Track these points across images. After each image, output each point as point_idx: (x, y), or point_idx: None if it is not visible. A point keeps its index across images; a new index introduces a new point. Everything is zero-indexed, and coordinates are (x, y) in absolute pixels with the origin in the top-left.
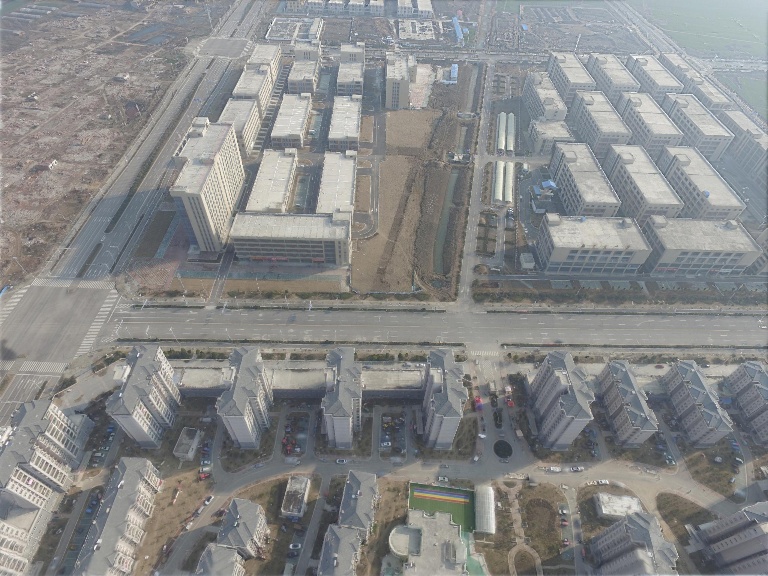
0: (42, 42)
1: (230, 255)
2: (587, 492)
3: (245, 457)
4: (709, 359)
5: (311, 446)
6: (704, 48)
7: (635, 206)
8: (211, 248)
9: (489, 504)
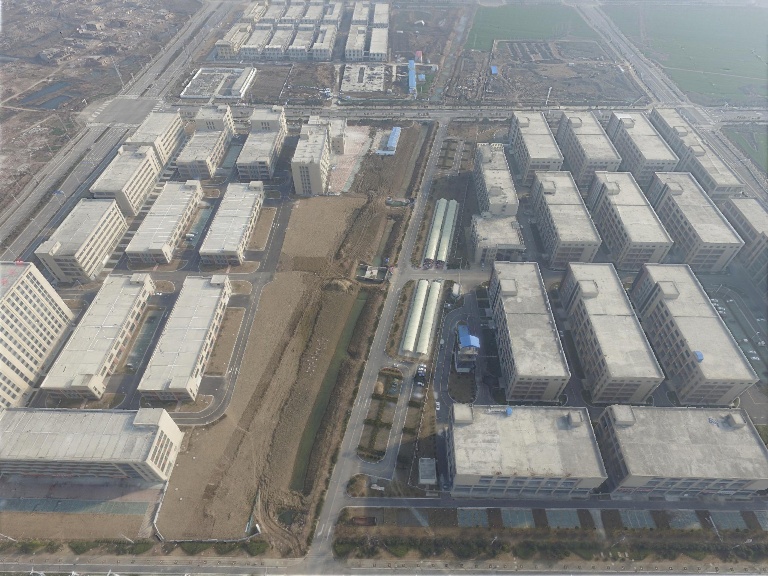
0: None
1: None
2: None
3: None
4: None
5: None
6: (712, 91)
7: (596, 369)
8: None
9: None
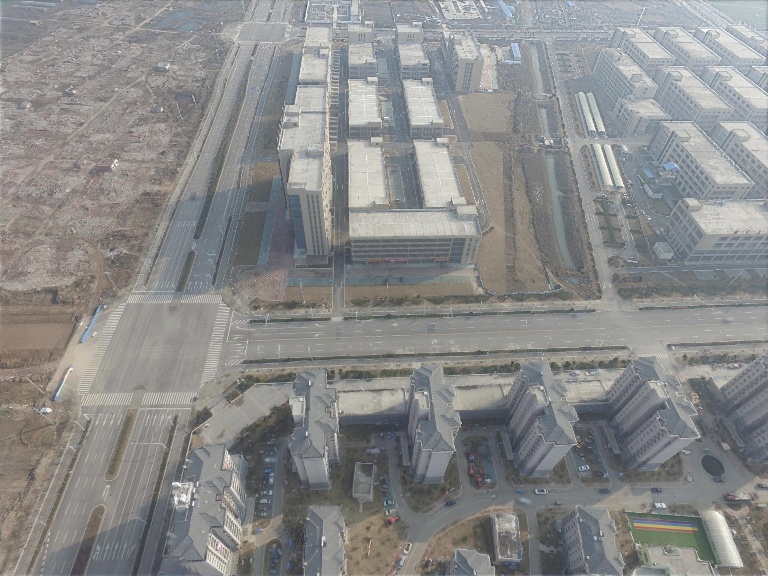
0: (64, 32)
1: (341, 258)
2: None
3: (432, 493)
4: None
5: (501, 475)
6: (757, 20)
7: (761, 186)
8: (319, 251)
9: (726, 533)
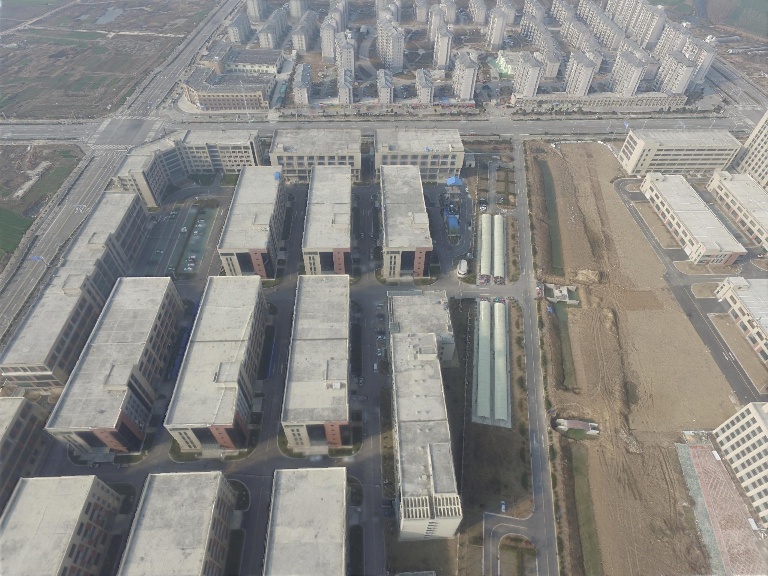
0: None
1: None
2: (447, 79)
3: None
4: (352, 116)
5: None
6: None
7: None
8: None
9: (493, 73)
